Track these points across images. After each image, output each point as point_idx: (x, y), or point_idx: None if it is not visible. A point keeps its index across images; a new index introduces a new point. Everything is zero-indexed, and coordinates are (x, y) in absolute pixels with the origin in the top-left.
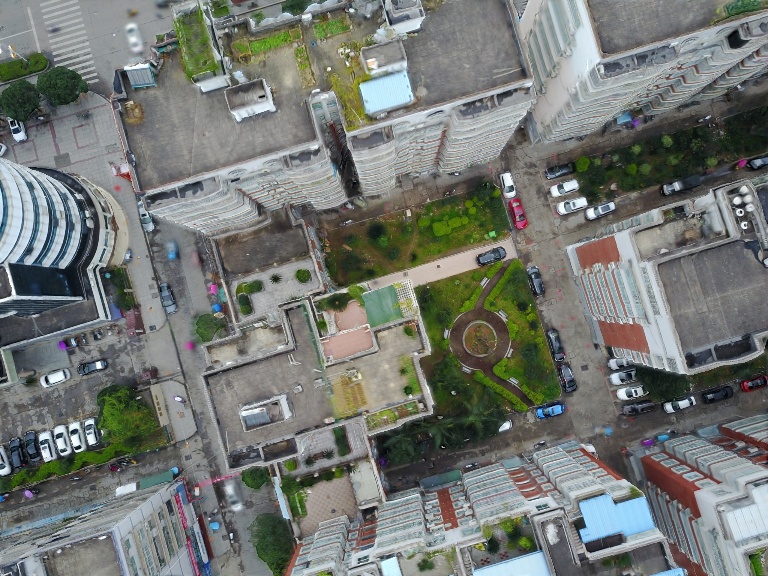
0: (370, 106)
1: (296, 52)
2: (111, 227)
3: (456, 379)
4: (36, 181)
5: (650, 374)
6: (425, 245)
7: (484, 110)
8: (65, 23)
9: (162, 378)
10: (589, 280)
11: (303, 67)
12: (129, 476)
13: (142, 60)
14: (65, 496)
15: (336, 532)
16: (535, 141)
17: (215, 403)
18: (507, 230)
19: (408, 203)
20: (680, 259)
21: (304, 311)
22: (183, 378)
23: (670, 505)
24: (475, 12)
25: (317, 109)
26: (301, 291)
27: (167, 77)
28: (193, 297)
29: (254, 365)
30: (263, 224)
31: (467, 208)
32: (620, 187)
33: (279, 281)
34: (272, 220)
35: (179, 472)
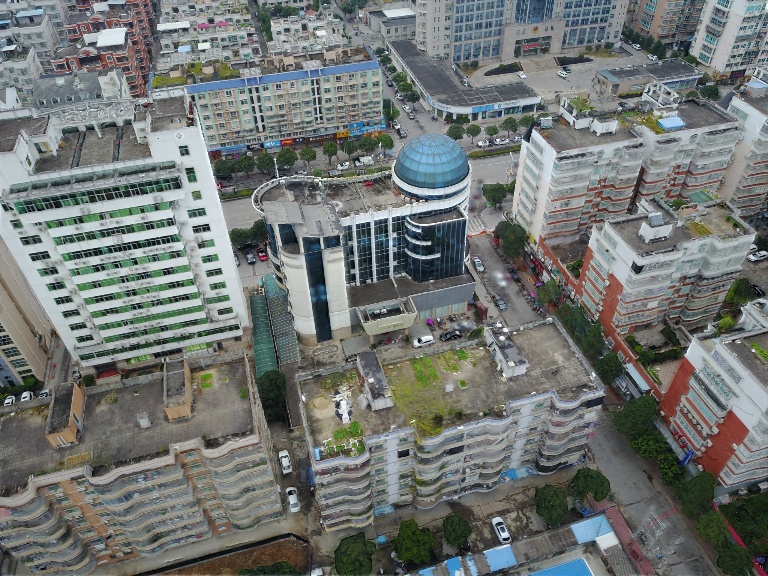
0: (665, 126)
1: None
2: None
3: None
4: None
5: None
6: None
7: None
8: None
9: None
10: None
11: (623, 123)
12: None
13: None
14: None
15: None
16: None
17: None
18: None
19: None
20: None
21: None
22: None
23: None
24: None
25: None
26: None
27: None
28: (516, 303)
29: (635, 221)
30: (575, 240)
31: None
32: None
33: None
34: (579, 239)
35: None
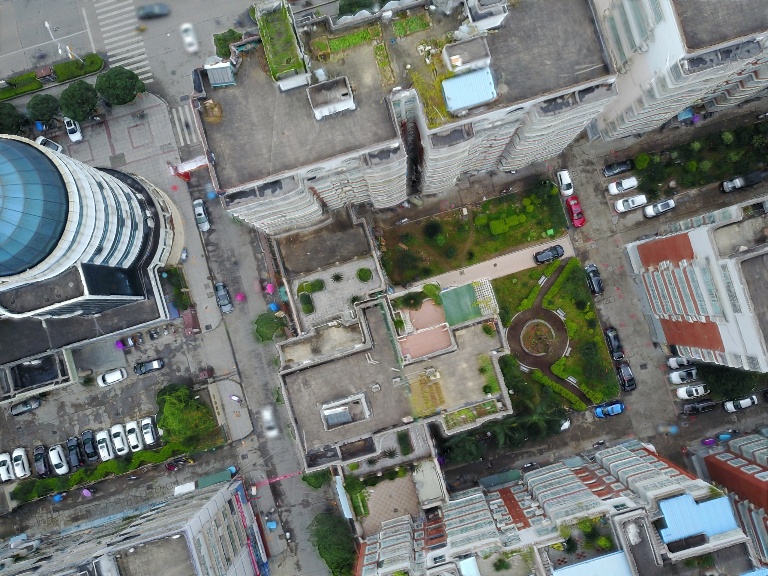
0: (452, 103)
1: (375, 50)
2: (170, 227)
3: (516, 378)
4: (104, 181)
5: (713, 373)
6: (482, 243)
7: (565, 107)
8: (120, 23)
9: (218, 377)
10: (653, 278)
11: (382, 65)
12: (186, 475)
13: (219, 59)
14: (122, 495)
15: (403, 532)
16: (593, 138)
17: (292, 402)
18: (564, 228)
19: (464, 201)
20: (763, 256)
21: (381, 310)
22: (239, 377)
23: (740, 505)
24: (556, 8)
25: (394, 107)
26: (362, 290)
27: (246, 76)
28: (248, 296)
29: (331, 364)
30: (324, 223)
31: (524, 206)
32: (680, 184)
33: (341, 280)
34: (333, 219)
35: (236, 471)
